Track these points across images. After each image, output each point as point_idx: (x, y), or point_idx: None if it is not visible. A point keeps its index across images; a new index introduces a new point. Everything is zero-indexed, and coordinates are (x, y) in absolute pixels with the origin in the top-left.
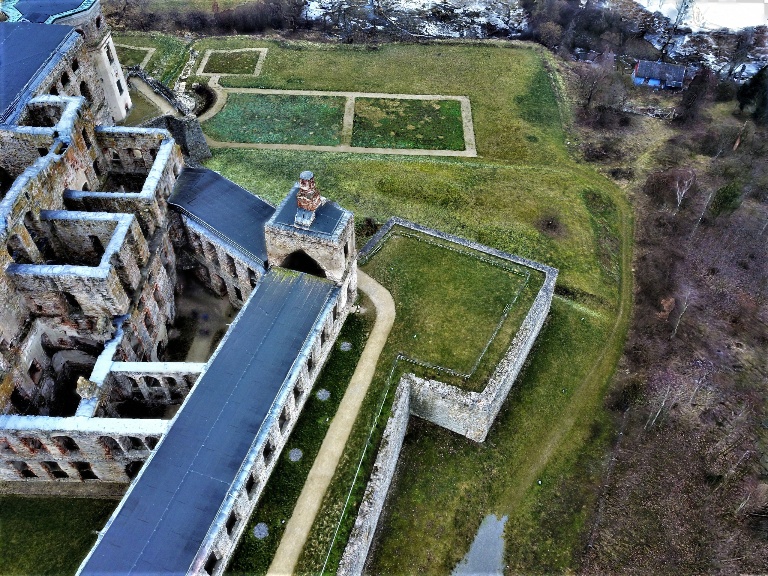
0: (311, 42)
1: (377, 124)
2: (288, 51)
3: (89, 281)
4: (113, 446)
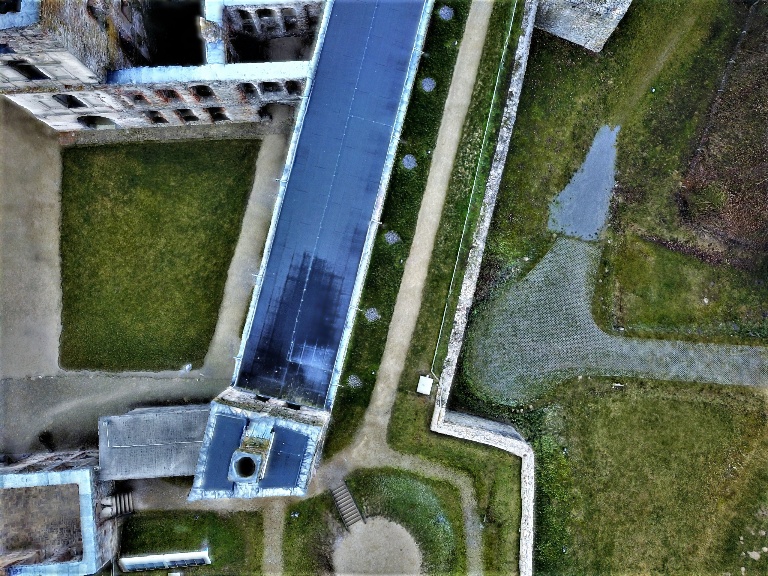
0: None
1: None
2: None
3: None
4: (245, 89)
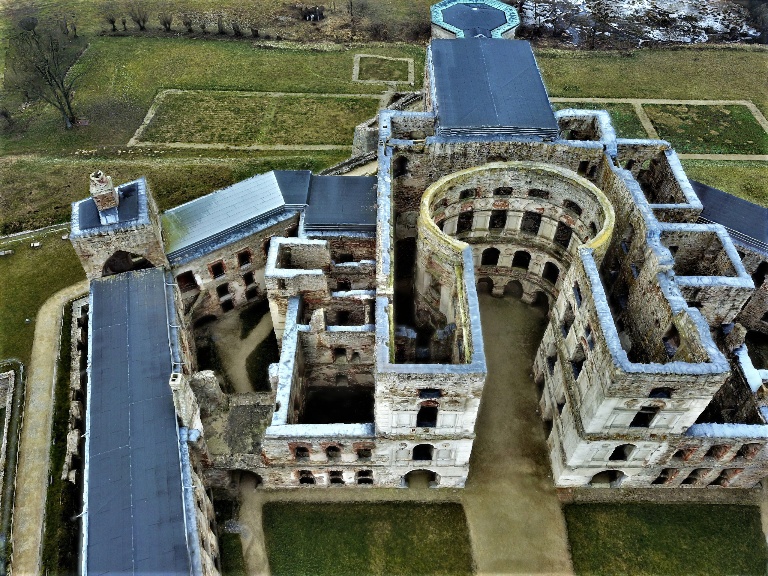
0: (559, 50)
1: (679, 130)
2: (544, 59)
3: (736, 291)
4: None
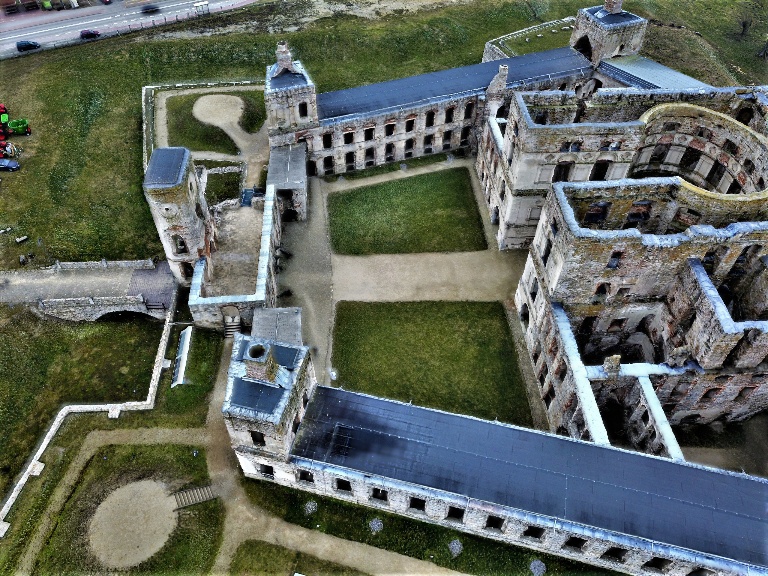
0: None
1: None
2: None
3: (715, 322)
4: (574, 408)
